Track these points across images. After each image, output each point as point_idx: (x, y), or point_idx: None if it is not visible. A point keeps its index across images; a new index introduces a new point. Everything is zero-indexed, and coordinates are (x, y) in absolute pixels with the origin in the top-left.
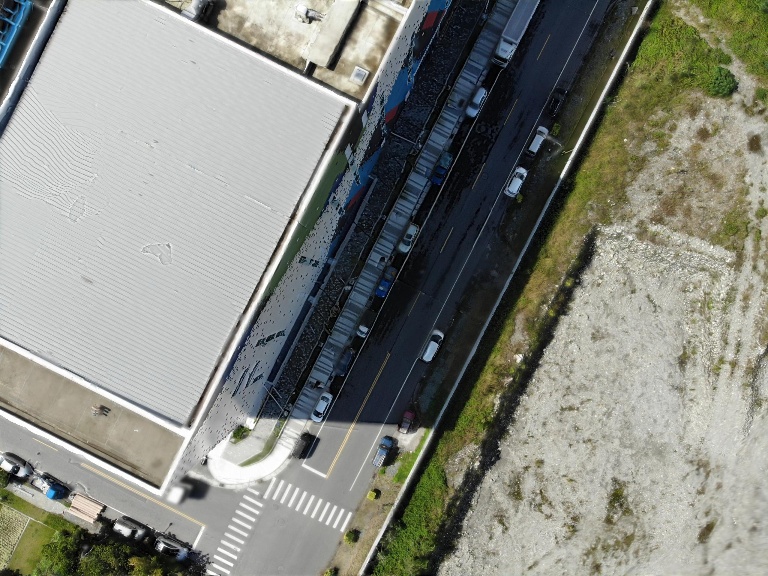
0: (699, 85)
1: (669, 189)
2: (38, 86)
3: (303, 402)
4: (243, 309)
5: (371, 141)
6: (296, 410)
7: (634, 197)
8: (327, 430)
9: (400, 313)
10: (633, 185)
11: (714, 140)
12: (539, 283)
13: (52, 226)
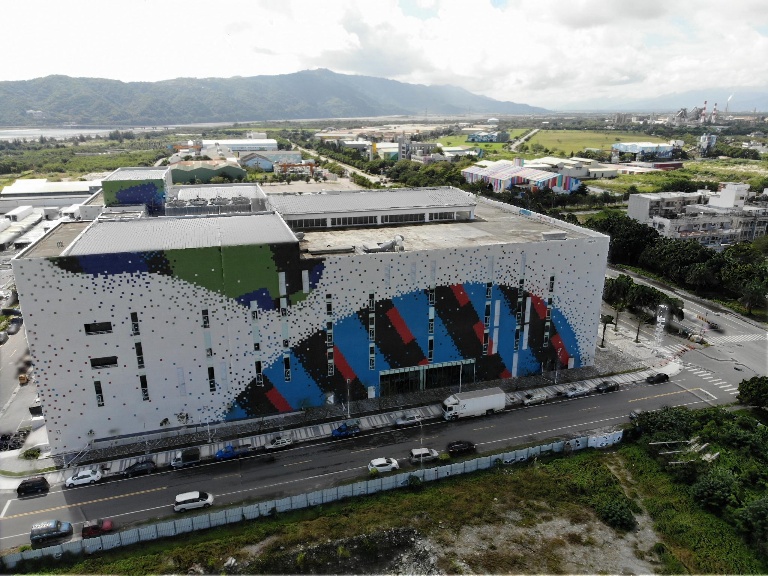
0: (594, 506)
1: (504, 551)
2: (220, 220)
3: (83, 470)
4: None
5: (312, 344)
6: (72, 471)
7: (466, 535)
8: (59, 495)
9: (211, 474)
10: (473, 527)
11: (582, 549)
12: (319, 526)
13: None
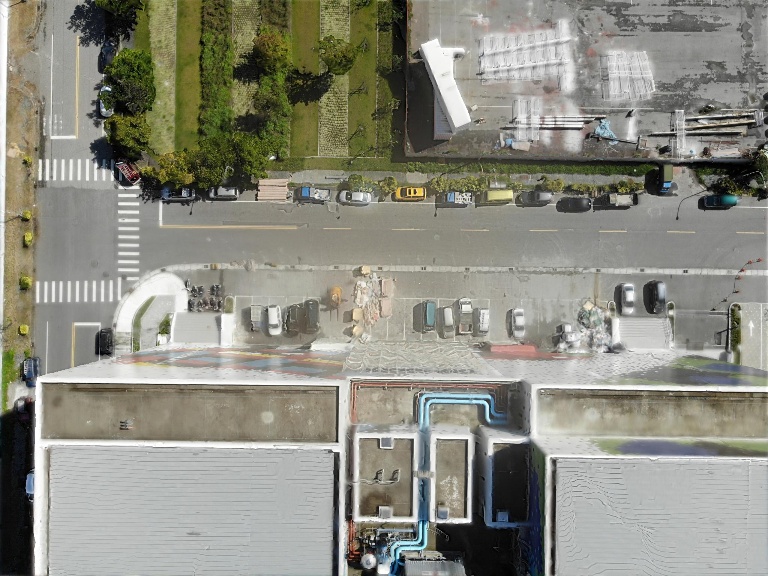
0: None
1: None
2: None
3: None
4: (51, 570)
5: None
6: None
7: None
8: None
9: None
10: None
11: None
12: None
13: (243, 569)
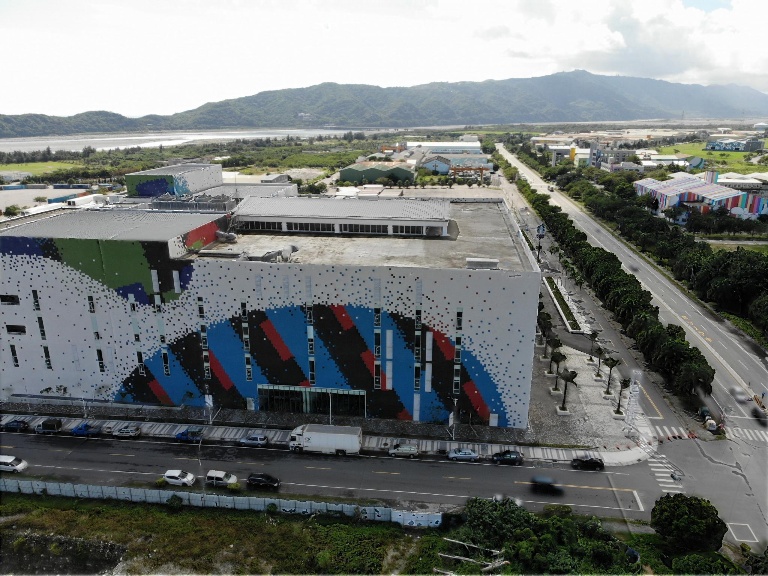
0: None
1: None
2: None
3: None
4: None
5: (188, 343)
6: None
7: (160, 572)
8: None
9: (54, 445)
10: (176, 567)
11: None
12: (60, 517)
13: None
